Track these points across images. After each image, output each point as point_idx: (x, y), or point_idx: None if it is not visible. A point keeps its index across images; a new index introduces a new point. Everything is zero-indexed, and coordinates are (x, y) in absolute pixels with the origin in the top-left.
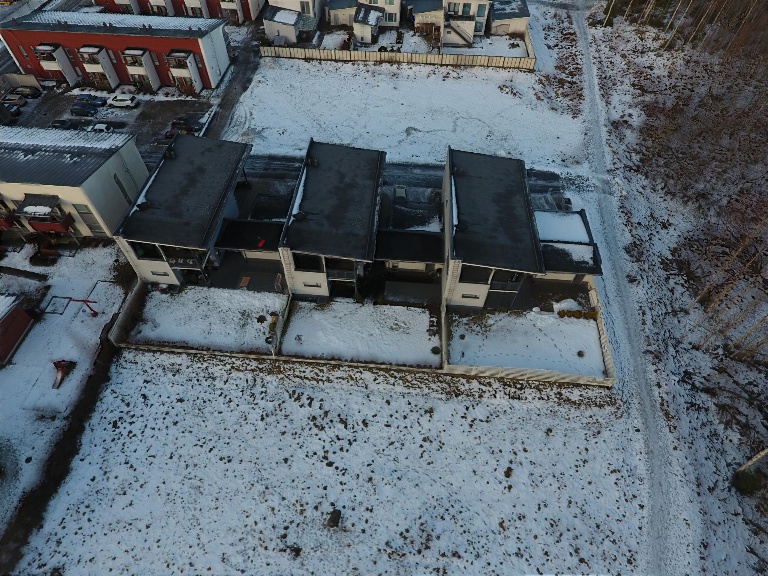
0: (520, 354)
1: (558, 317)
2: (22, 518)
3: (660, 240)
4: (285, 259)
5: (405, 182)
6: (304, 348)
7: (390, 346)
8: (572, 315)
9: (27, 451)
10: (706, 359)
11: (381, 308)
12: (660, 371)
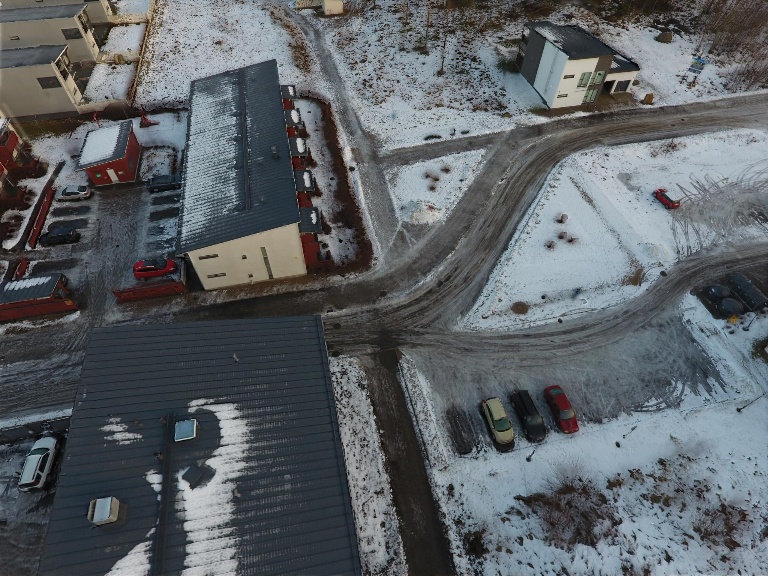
0: (141, 8)
1: None
2: None
3: None
4: (80, 24)
5: None
6: None
7: None
8: None
9: None
10: None
11: (110, 38)
12: None
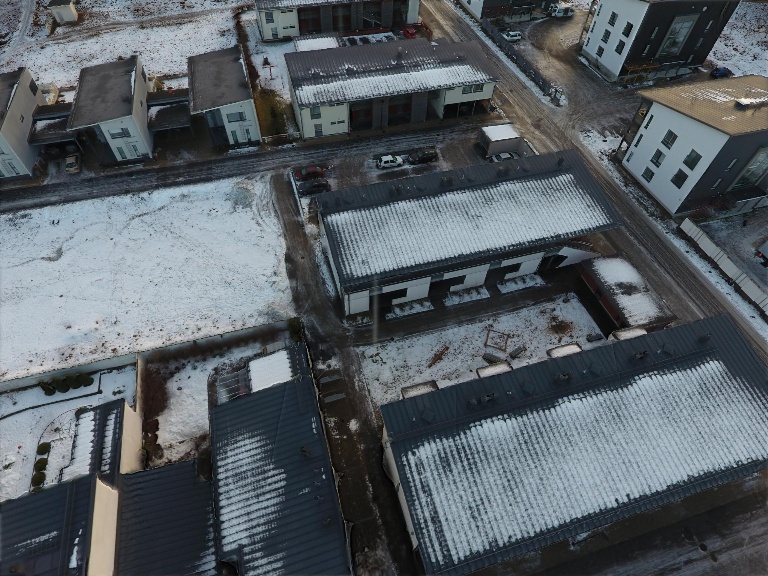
0: None
1: None
2: None
3: None
4: None
5: (69, 185)
6: None
7: None
8: None
9: None
10: None
11: None
12: None
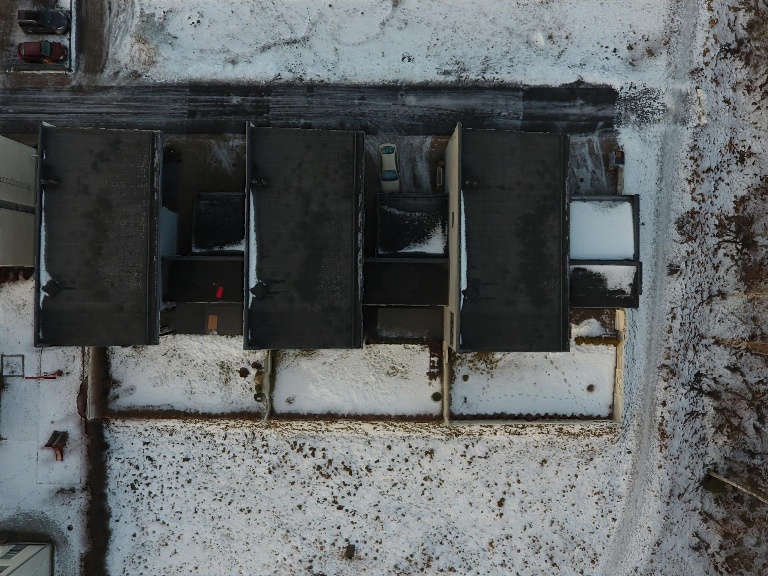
0: (526, 394)
1: (574, 345)
2: (90, 573)
3: (728, 186)
4: None
5: (394, 126)
6: (297, 405)
7: (388, 396)
8: (591, 342)
9: (65, 521)
10: (724, 357)
11: (375, 348)
12: (670, 389)
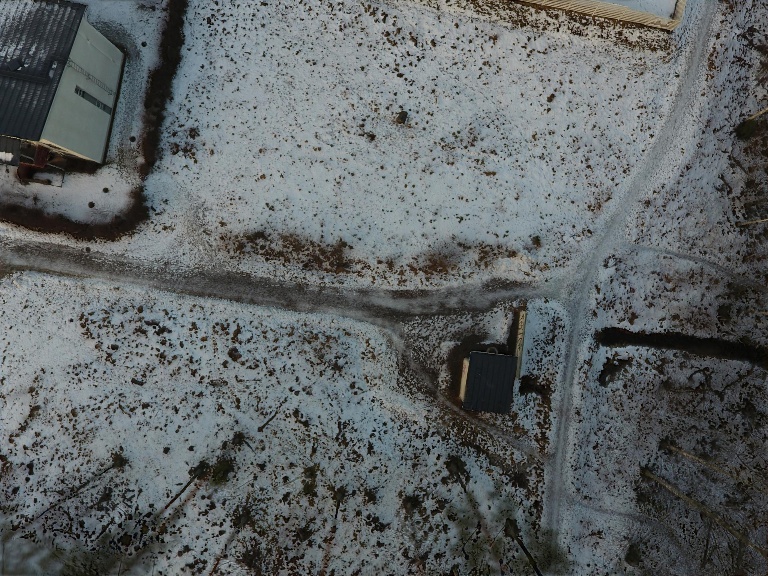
0: None
1: None
2: (155, 90)
3: None
4: None
5: None
6: None
7: None
8: None
9: (140, 36)
10: None
11: None
12: (726, 22)
